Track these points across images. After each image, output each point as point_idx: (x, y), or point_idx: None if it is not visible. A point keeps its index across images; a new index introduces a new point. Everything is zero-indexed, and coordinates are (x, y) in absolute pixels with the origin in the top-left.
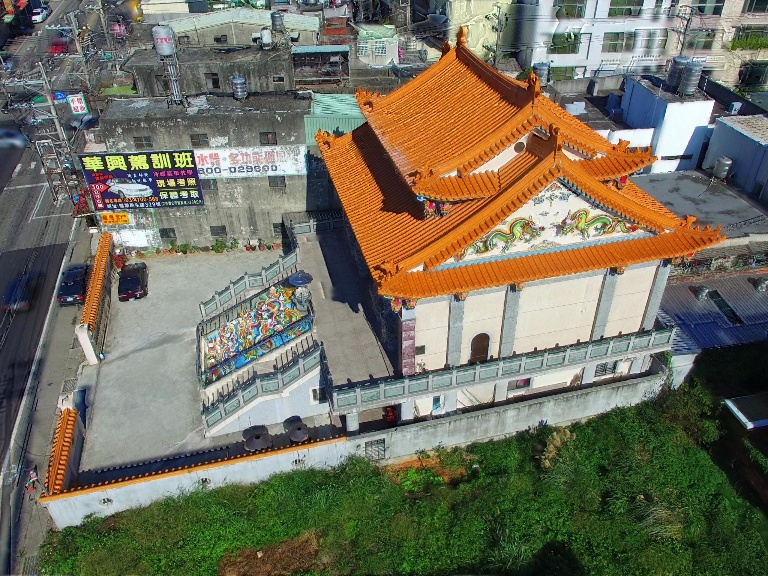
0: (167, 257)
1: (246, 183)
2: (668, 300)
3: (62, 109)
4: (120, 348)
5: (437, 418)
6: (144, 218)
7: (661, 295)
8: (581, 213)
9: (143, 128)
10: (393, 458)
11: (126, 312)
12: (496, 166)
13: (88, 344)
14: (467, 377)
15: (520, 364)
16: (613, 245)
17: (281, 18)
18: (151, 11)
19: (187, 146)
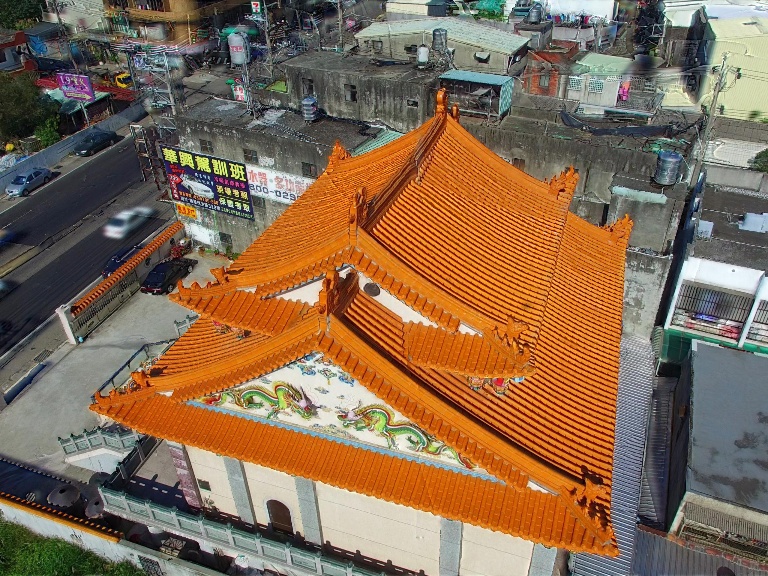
0: (220, 261)
1: None
2: (664, 572)
3: (227, 95)
4: (102, 337)
5: (236, 568)
6: (208, 218)
7: (548, 575)
8: (374, 410)
9: (206, 132)
10: None
11: (140, 304)
12: (311, 298)
13: (67, 325)
14: (249, 544)
15: (315, 563)
16: (438, 473)
17: (441, 36)
18: (394, 10)
19: (241, 159)
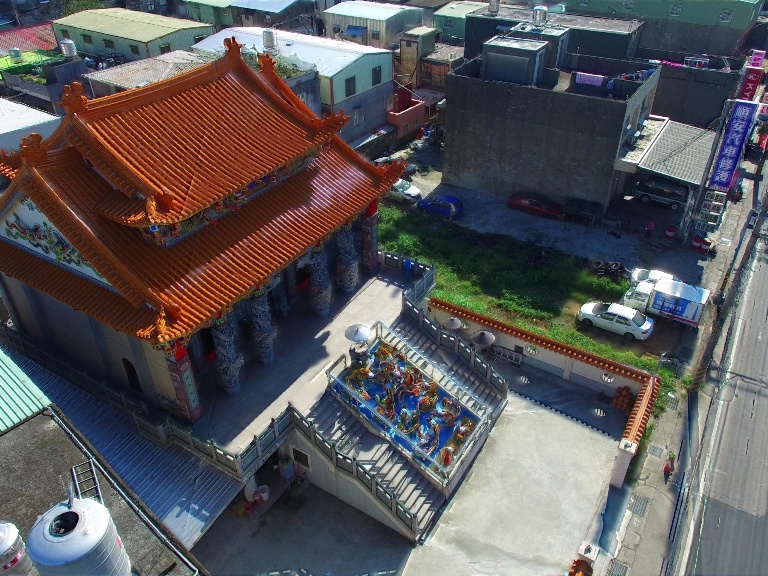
0: None
1: None
2: None
3: None
4: None
5: None
6: None
7: None
8: None
9: None
10: None
11: None
12: None
13: None
14: None
15: None
16: None
17: None
18: None
19: None
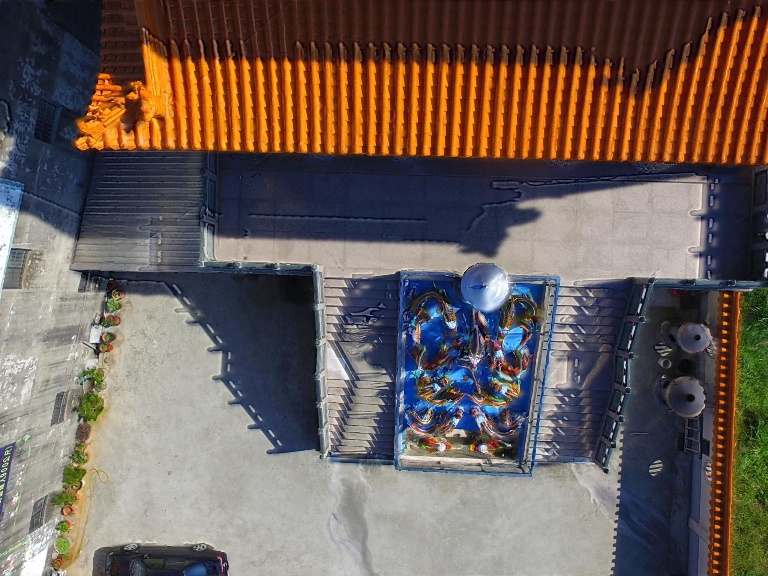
0: (86, 508)
1: (1, 346)
2: None
3: None
4: None
5: None
6: (4, 573)
7: None
8: None
9: None
10: None
11: None
12: None
13: None
14: None
15: None
16: None
17: None
18: None
19: None
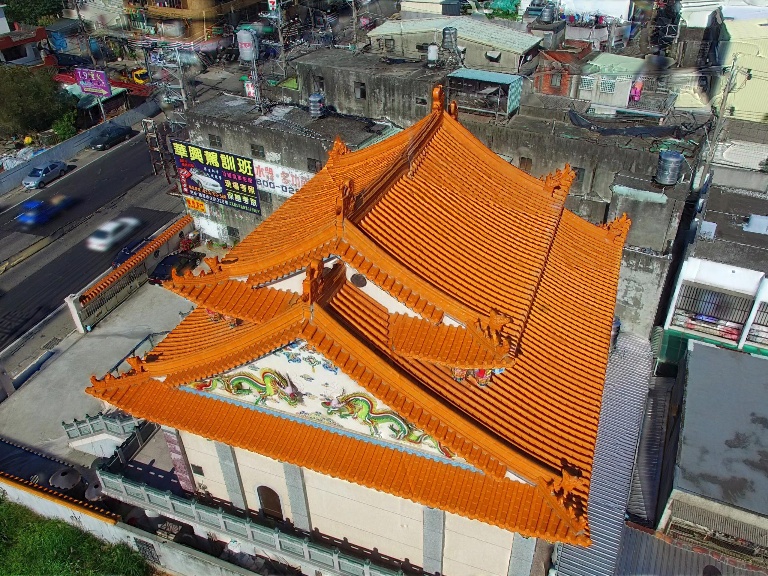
0: None
1: None
2: (649, 568)
3: (240, 92)
4: (110, 327)
5: (228, 553)
6: (216, 212)
7: (528, 566)
8: (357, 398)
9: (215, 127)
10: (169, 569)
11: (148, 295)
12: (300, 288)
13: (76, 314)
14: (239, 528)
15: (302, 549)
16: (420, 462)
17: (451, 35)
18: (408, 8)
19: (248, 154)
